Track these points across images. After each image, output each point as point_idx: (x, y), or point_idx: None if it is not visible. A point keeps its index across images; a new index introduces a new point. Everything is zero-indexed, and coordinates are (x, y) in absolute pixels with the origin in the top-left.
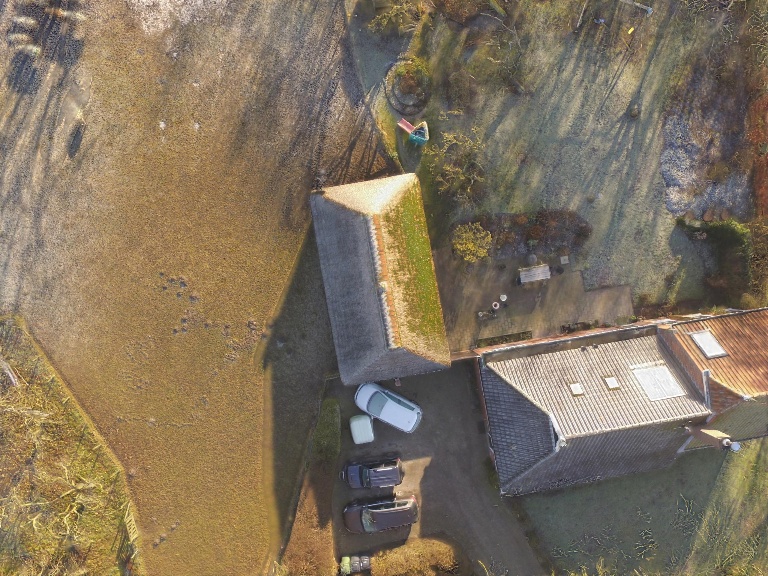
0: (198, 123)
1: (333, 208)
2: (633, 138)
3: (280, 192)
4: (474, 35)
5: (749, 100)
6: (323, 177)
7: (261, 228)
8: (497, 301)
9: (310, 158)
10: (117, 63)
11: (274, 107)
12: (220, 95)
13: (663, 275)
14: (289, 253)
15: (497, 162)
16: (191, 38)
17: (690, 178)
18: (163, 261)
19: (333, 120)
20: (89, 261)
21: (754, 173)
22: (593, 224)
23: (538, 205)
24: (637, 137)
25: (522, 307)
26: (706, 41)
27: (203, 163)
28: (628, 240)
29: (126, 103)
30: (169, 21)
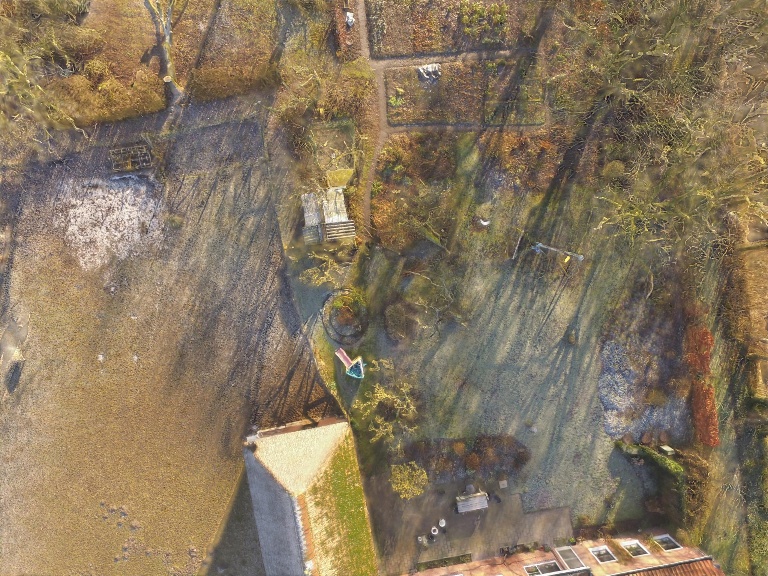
0: (136, 355)
1: (263, 471)
2: (571, 363)
3: (219, 422)
4: (411, 264)
5: (687, 321)
6: (261, 406)
7: (200, 457)
8: (436, 526)
9: (248, 388)
10: (55, 299)
11: (212, 338)
12: (158, 328)
13: (602, 497)
14: (228, 482)
15: (435, 387)
16: (128, 273)
17: (628, 402)
18: (103, 491)
19: (271, 350)
20: (29, 493)
21: (693, 394)
22: (531, 448)
23: (476, 430)
24: (575, 362)
25: (461, 530)
26: (644, 263)
27: (142, 395)
28: (567, 463)
29: (64, 338)
30: (106, 257)
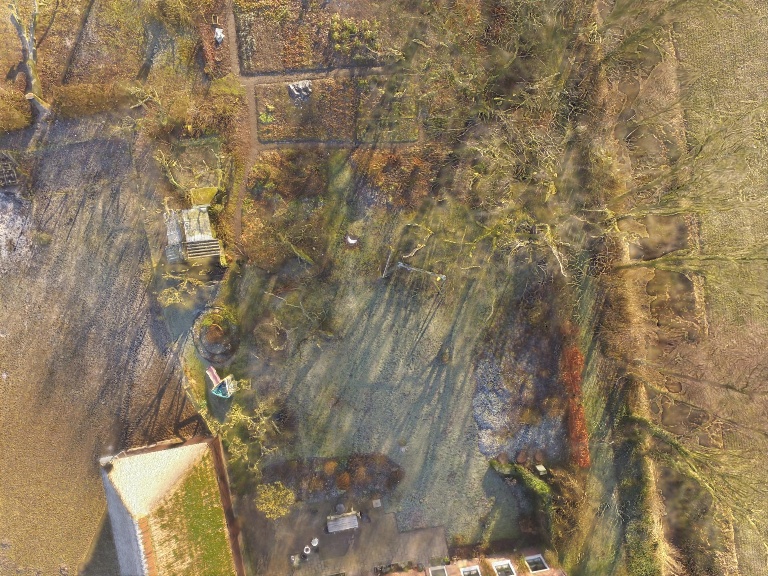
0: (5, 373)
1: (114, 493)
2: (445, 382)
3: (89, 440)
4: (282, 282)
5: (564, 340)
6: (132, 425)
7: (71, 476)
8: (309, 545)
9: (119, 406)
10: None
11: (82, 356)
12: (27, 345)
13: (477, 516)
14: (99, 500)
15: (308, 406)
16: None
17: (502, 421)
18: None
19: (141, 368)
20: None
21: (569, 413)
22: (405, 467)
23: (350, 449)
24: (449, 381)
25: (335, 549)
26: (520, 282)
27: (11, 413)
28: (441, 482)
29: None
30: None
